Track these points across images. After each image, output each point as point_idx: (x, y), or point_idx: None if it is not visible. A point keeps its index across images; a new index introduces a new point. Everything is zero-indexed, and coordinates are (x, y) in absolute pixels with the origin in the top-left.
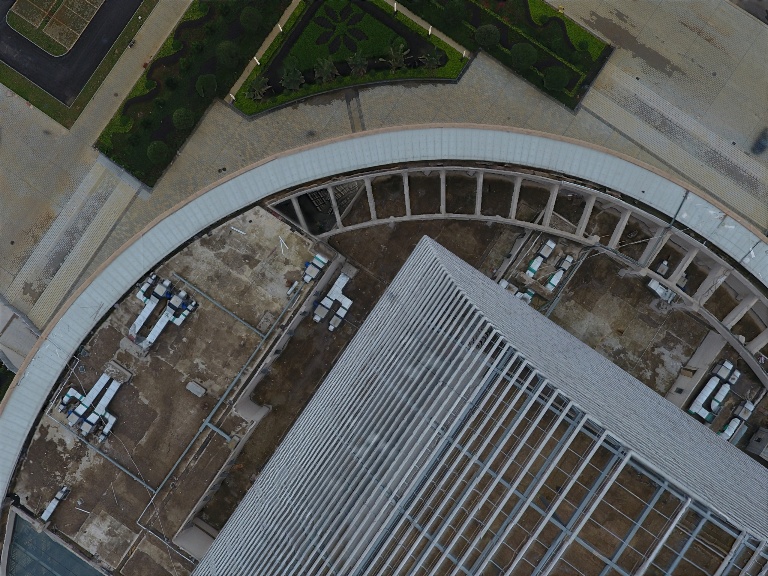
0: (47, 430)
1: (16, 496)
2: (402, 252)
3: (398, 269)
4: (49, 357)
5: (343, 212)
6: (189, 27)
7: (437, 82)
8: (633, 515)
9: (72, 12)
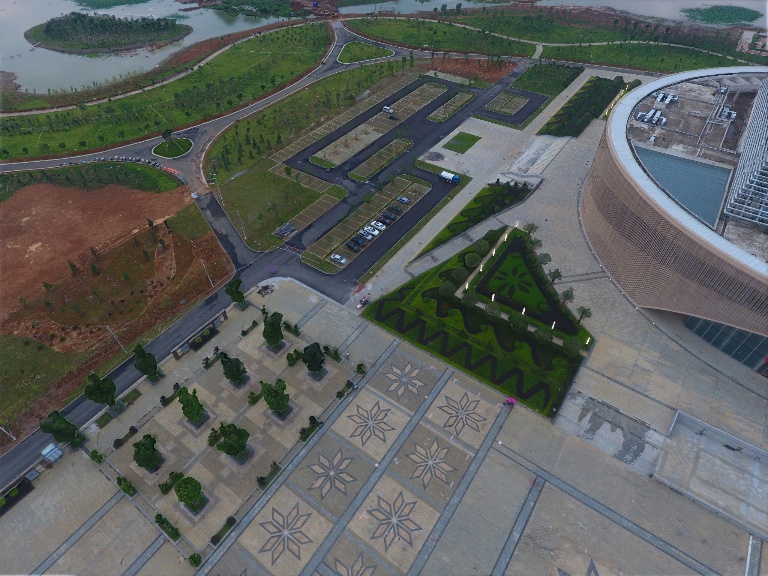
0: None
1: None
2: None
3: (747, 110)
4: None
5: None
6: None
7: None
8: None
9: None
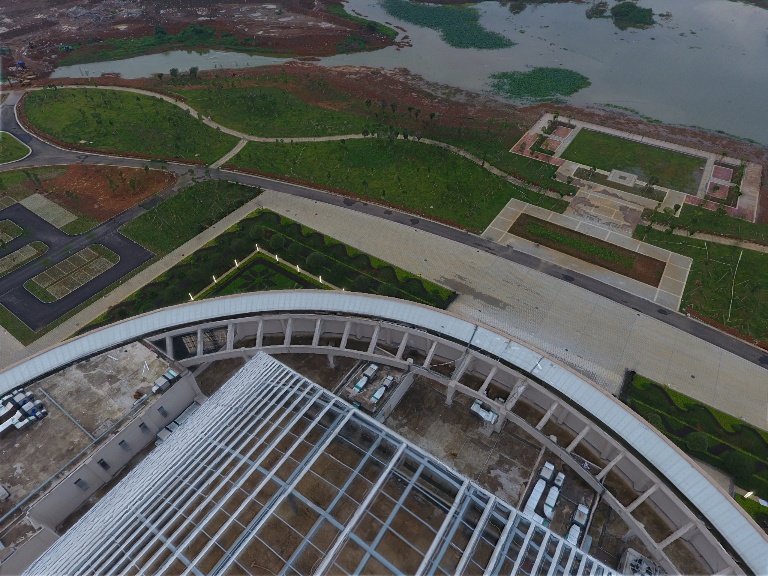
0: None
1: None
2: None
3: None
4: None
5: None
6: (153, 286)
7: None
8: (352, 464)
9: (74, 280)
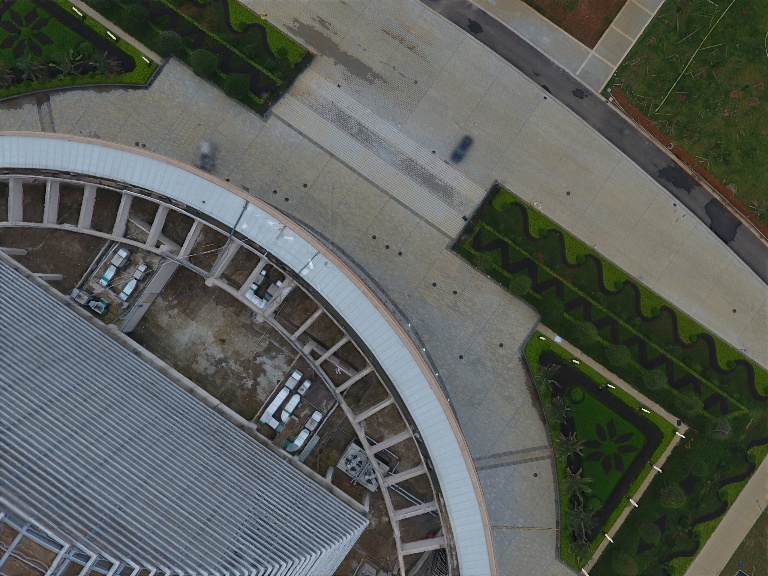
0: None
1: None
2: None
3: None
4: None
5: None
6: None
7: (128, 87)
8: None
9: None
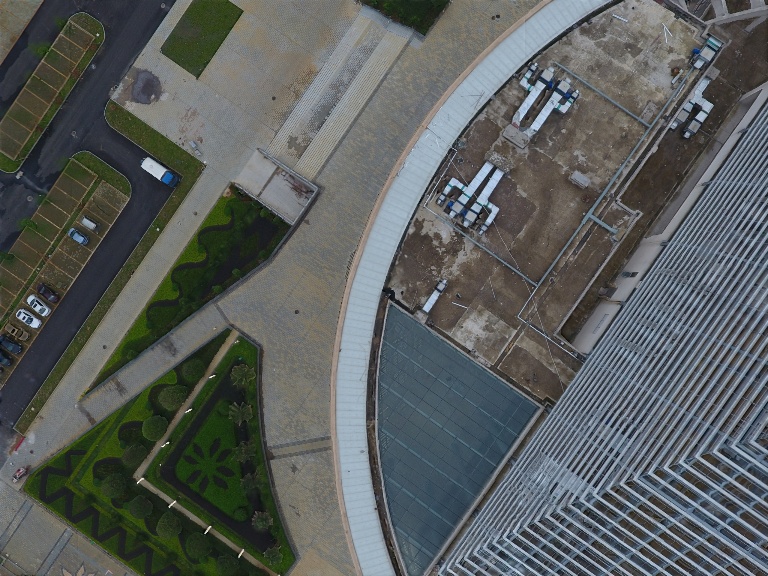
0: (422, 224)
1: (392, 290)
2: (758, 58)
3: (753, 76)
4: (429, 147)
5: (703, 13)
6: None
7: None
8: None
9: None
